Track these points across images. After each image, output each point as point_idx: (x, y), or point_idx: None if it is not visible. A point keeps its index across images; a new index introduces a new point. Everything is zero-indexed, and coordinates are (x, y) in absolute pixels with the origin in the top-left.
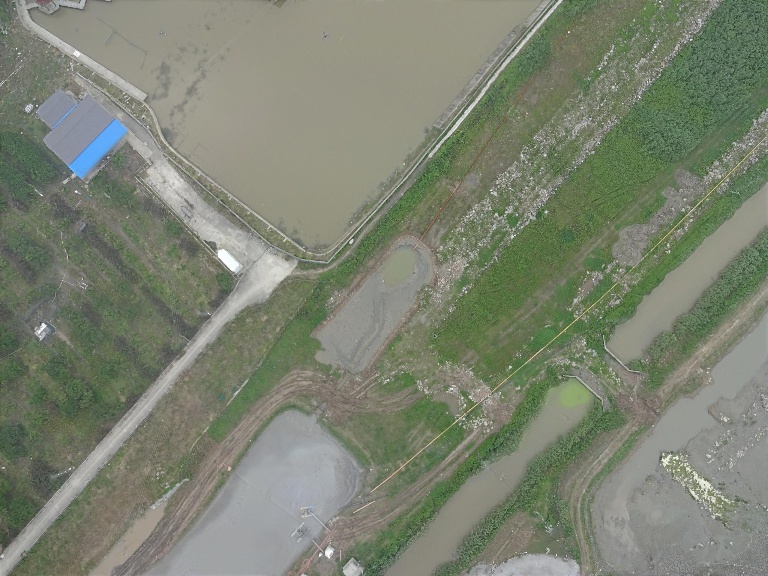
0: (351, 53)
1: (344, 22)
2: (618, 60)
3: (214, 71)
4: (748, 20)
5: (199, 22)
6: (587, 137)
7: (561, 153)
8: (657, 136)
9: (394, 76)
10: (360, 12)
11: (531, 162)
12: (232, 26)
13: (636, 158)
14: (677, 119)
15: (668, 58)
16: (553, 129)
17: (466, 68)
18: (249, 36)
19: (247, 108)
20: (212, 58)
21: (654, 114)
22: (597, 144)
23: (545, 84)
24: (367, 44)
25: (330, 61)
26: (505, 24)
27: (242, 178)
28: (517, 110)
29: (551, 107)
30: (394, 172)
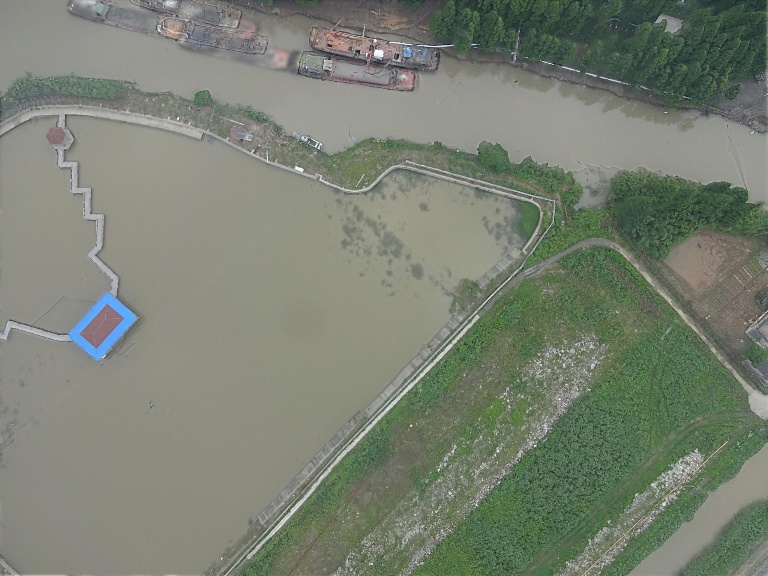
0: (177, 429)
1: (172, 395)
2: (458, 463)
3: (23, 435)
4: (593, 432)
5: (13, 376)
6: (417, 547)
7: (388, 564)
8: (489, 553)
9: (221, 459)
10: (190, 387)
11: (356, 570)
12: (50, 384)
13: (466, 573)
14: (511, 535)
15: (509, 465)
16: (383, 533)
17: (302, 449)
18: (62, 410)
19: (53, 487)
20: (16, 435)
21: (488, 528)
22: (427, 554)
23: (380, 482)
24: (195, 422)
25: (151, 440)
26: (348, 404)
27: (41, 562)
28: (348, 509)
29: (384, 508)
30: (210, 567)
